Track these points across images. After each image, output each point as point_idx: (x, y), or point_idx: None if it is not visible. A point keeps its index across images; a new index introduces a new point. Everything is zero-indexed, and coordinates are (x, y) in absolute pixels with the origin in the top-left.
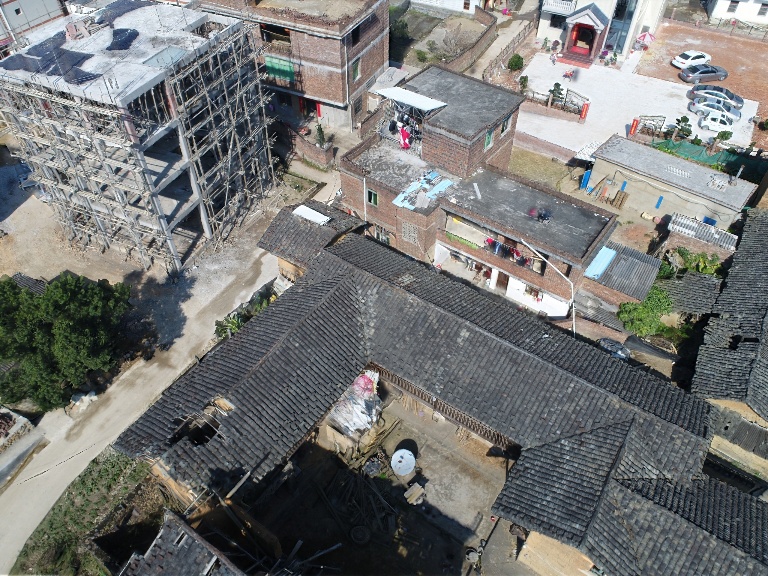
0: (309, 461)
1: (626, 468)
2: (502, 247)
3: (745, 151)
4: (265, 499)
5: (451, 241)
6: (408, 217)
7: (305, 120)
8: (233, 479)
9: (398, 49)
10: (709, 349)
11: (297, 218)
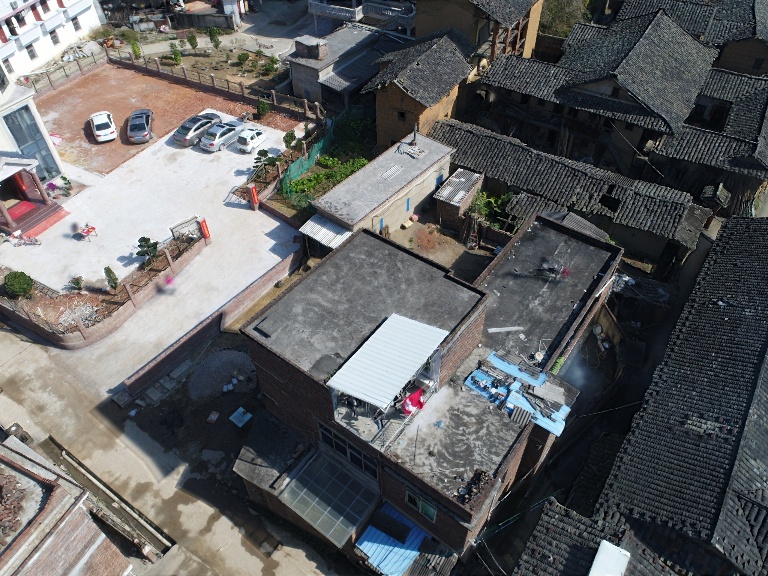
0: None
1: None
2: None
3: (307, 135)
4: None
5: None
6: None
7: None
8: None
9: None
10: (620, 217)
11: None
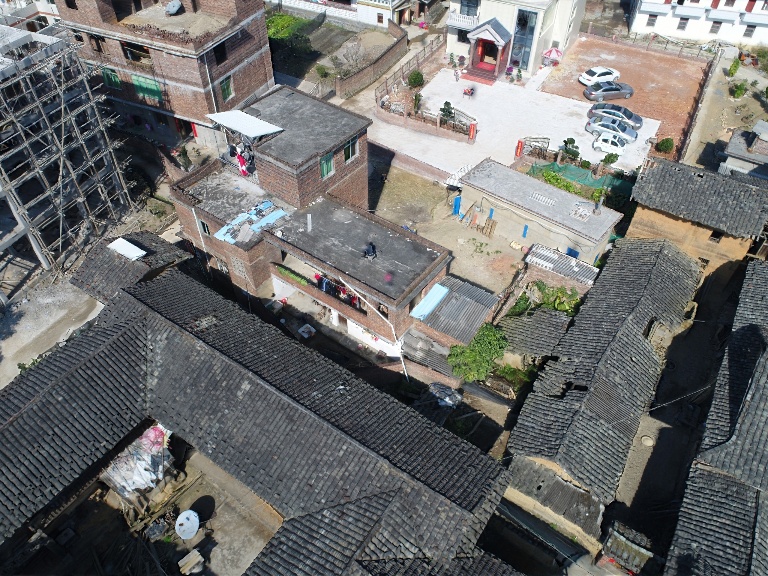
0: (91, 522)
1: (378, 547)
2: (328, 284)
3: (632, 175)
4: (5, 573)
5: (283, 276)
6: (233, 251)
7: (183, 140)
8: None
9: (302, 64)
10: (537, 397)
11: (113, 252)
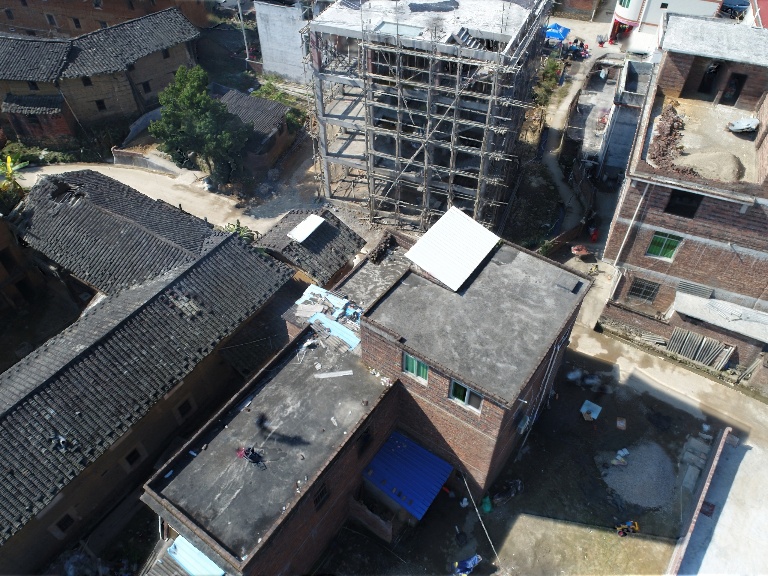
0: None
1: None
2: None
3: None
4: None
5: None
6: None
7: None
8: (27, 223)
9: None
10: None
11: None
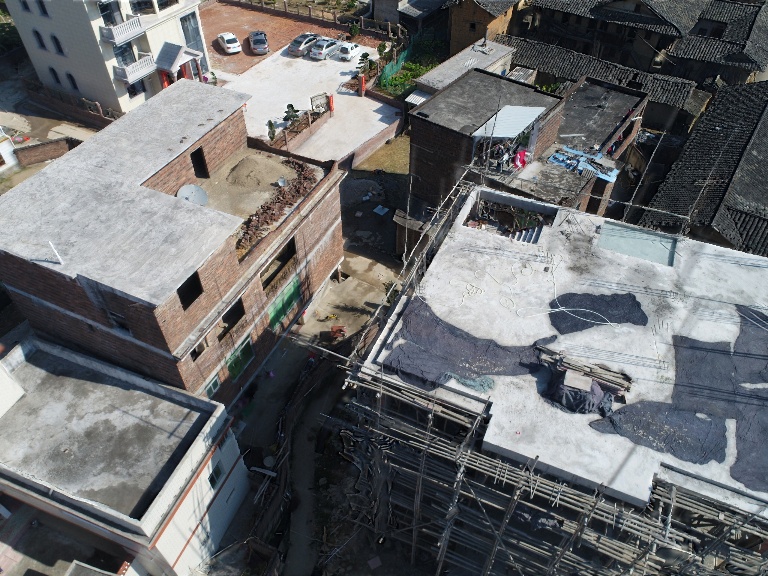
0: None
1: None
2: None
3: None
4: None
5: None
6: None
7: None
8: None
9: None
10: None
11: None
